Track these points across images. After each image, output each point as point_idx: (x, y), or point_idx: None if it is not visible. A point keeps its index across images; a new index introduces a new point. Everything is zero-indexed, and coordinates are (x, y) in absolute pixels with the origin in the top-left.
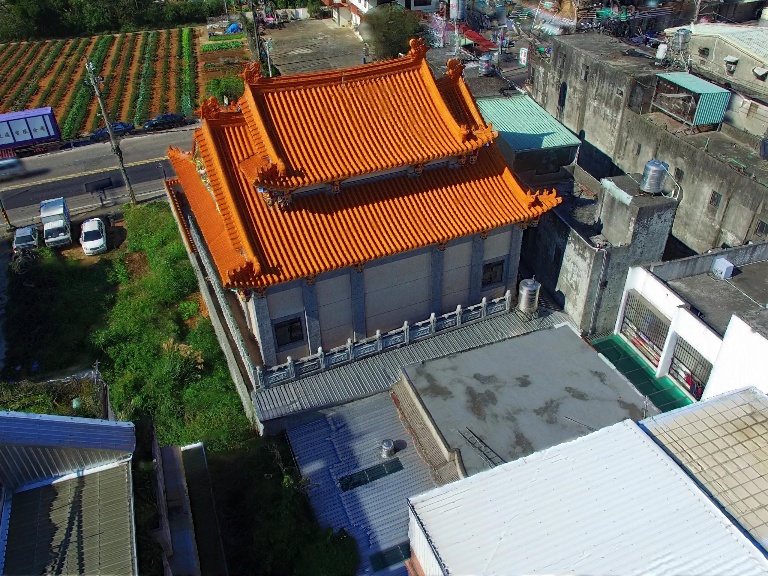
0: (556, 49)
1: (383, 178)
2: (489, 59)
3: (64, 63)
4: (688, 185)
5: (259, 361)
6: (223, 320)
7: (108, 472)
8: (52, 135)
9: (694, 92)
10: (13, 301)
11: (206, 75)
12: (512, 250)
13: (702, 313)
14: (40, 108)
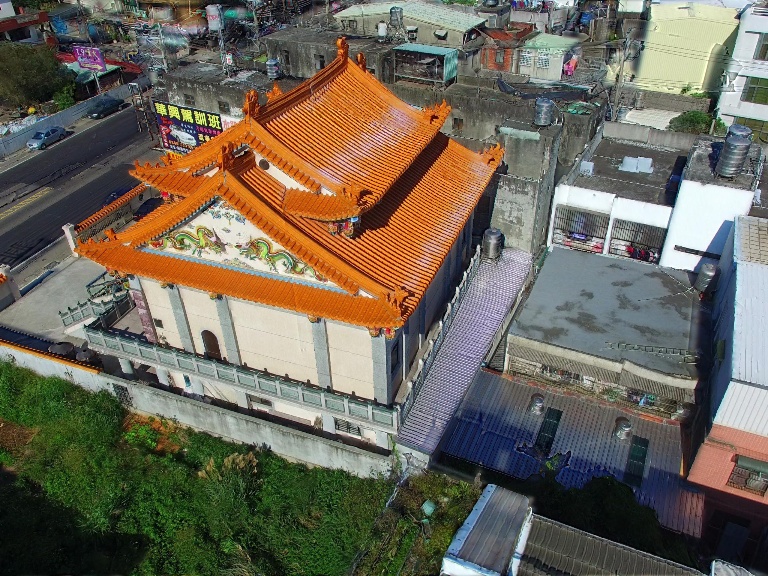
0: (274, 48)
1: None
2: (277, 62)
3: None
4: (470, 128)
5: None
6: None
7: (534, 534)
8: None
9: (439, 55)
10: None
11: None
12: None
13: None
14: None
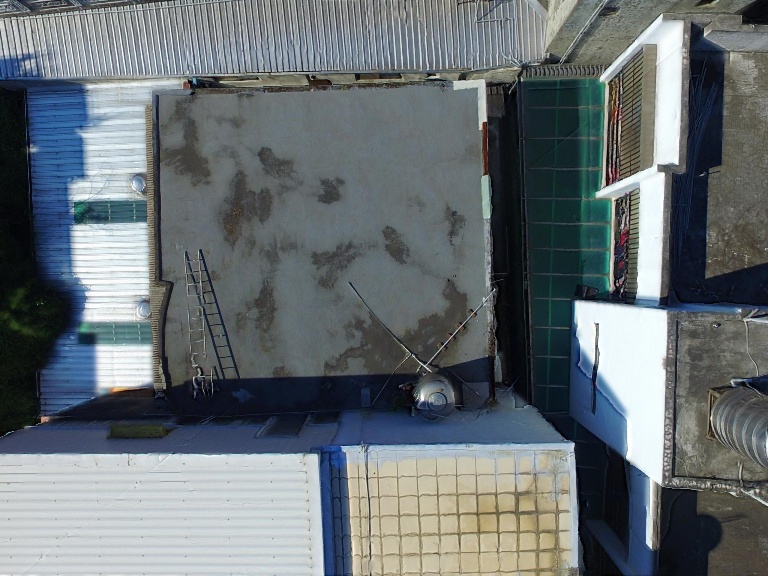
0: None
1: None
2: None
3: None
4: None
5: None
6: None
7: None
8: None
9: None
10: None
11: None
12: None
13: (721, 161)
14: None
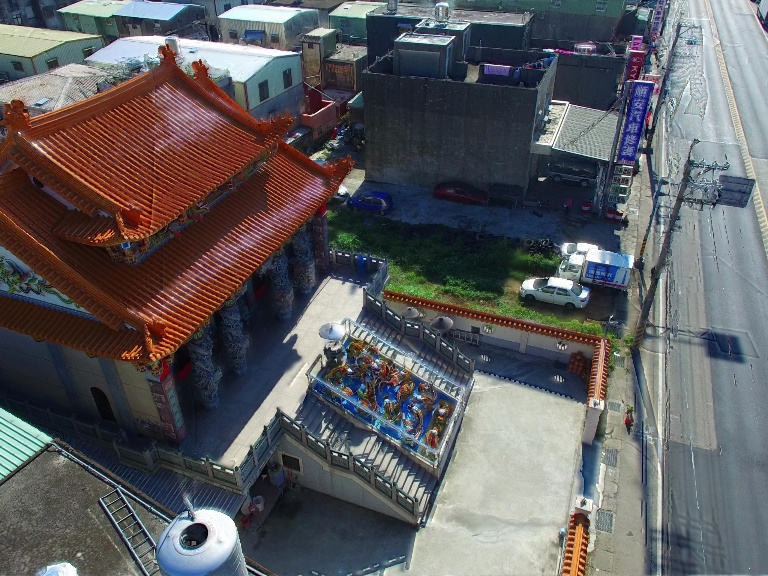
0: None
1: None
2: None
3: None
4: None
5: None
6: None
7: None
8: None
9: None
10: None
11: None
12: None
13: None
14: None
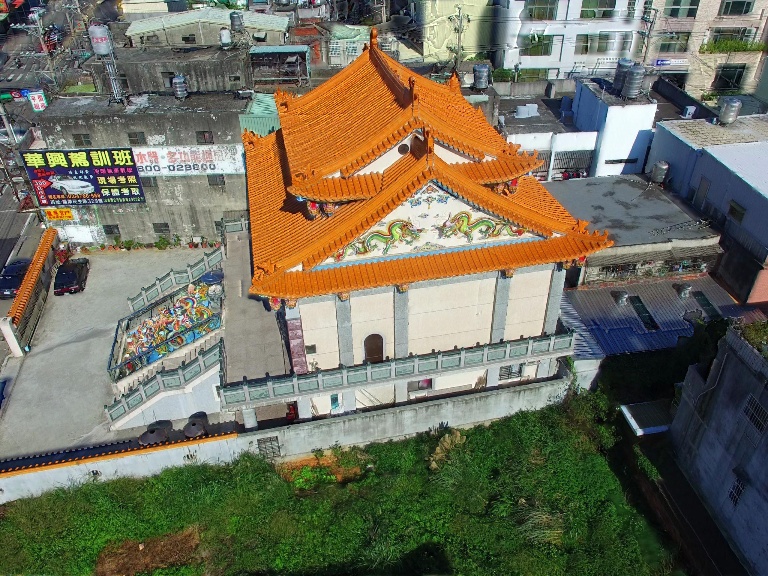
0: None
1: None
2: None
3: None
4: None
5: None
6: None
7: None
8: None
9: (301, 52)
10: None
11: None
12: None
13: None
14: None
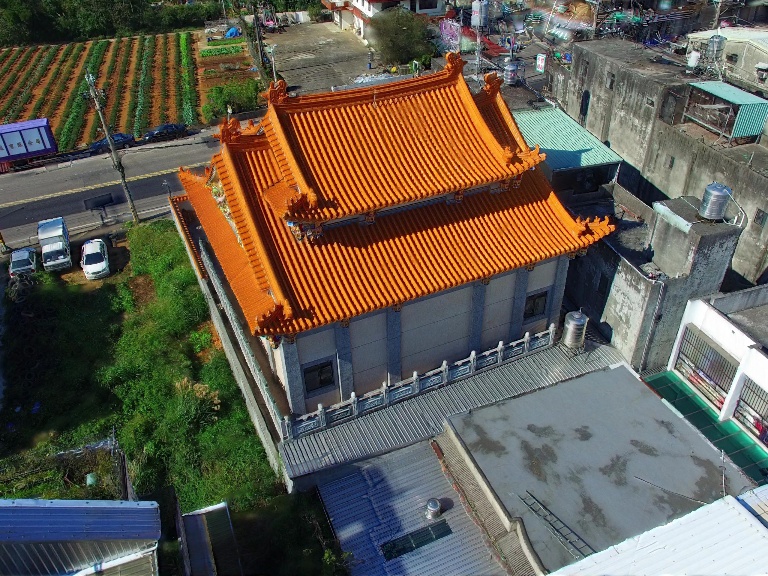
0: (578, 56)
1: (420, 205)
2: (515, 69)
3: (58, 70)
4: None
5: (285, 407)
6: (239, 354)
7: (130, 565)
8: (48, 148)
9: (733, 103)
10: (10, 333)
11: (206, 82)
12: (557, 281)
13: None
14: (35, 120)
